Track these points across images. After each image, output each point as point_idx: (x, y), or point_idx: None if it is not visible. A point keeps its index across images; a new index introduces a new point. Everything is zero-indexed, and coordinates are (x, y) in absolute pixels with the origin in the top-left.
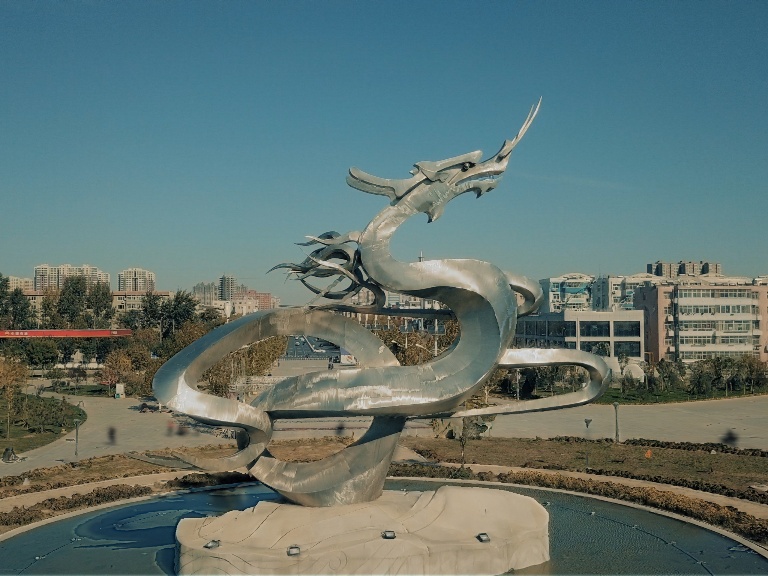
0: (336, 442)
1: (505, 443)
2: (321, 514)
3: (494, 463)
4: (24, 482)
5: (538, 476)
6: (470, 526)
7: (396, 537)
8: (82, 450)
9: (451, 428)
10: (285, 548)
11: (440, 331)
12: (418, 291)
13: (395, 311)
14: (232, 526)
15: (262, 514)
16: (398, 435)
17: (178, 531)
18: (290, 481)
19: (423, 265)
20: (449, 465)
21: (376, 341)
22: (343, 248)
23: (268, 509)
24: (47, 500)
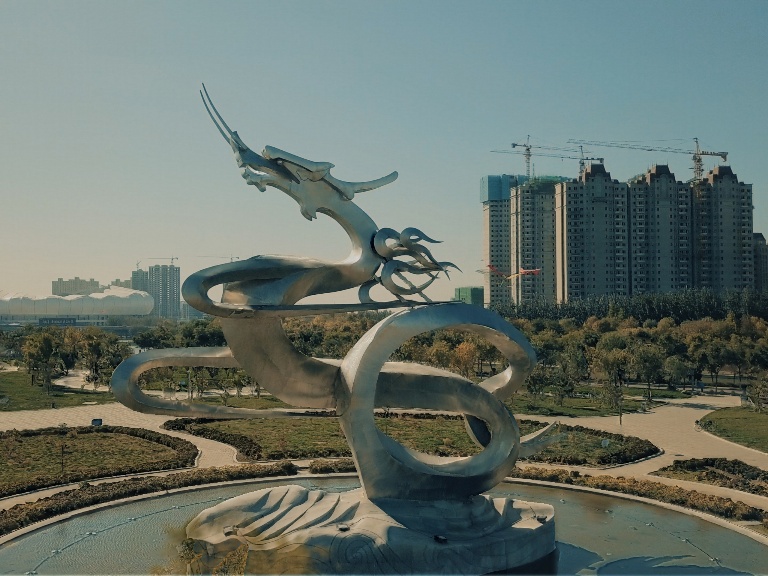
0: None
1: None
2: None
3: None
4: None
5: None
6: None
7: None
8: None
9: None
10: None
11: None
12: None
13: (350, 306)
14: None
15: None
16: None
17: None
18: None
19: None
20: None
21: None
22: None
23: None
24: None
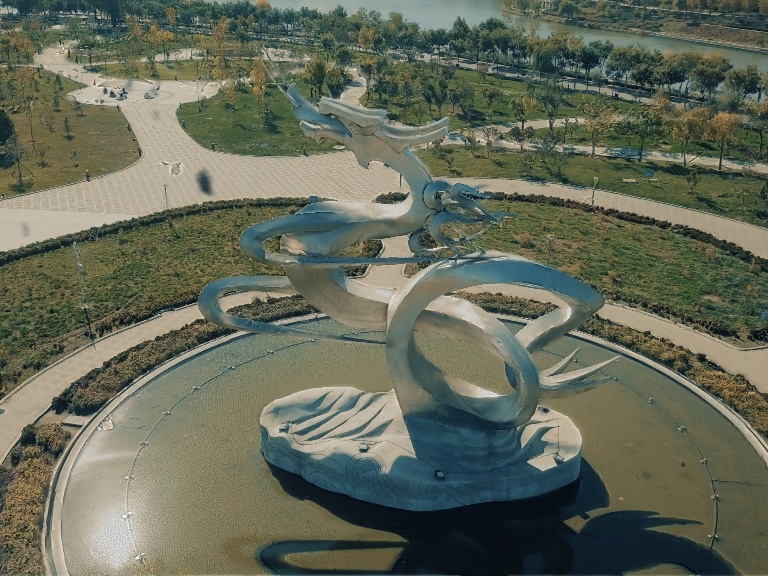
0: None
1: None
2: None
3: None
4: None
5: None
6: None
7: None
8: None
9: None
10: None
11: None
12: None
13: (393, 258)
14: None
15: None
16: None
17: None
18: None
19: None
20: None
21: None
22: None
23: None
24: None
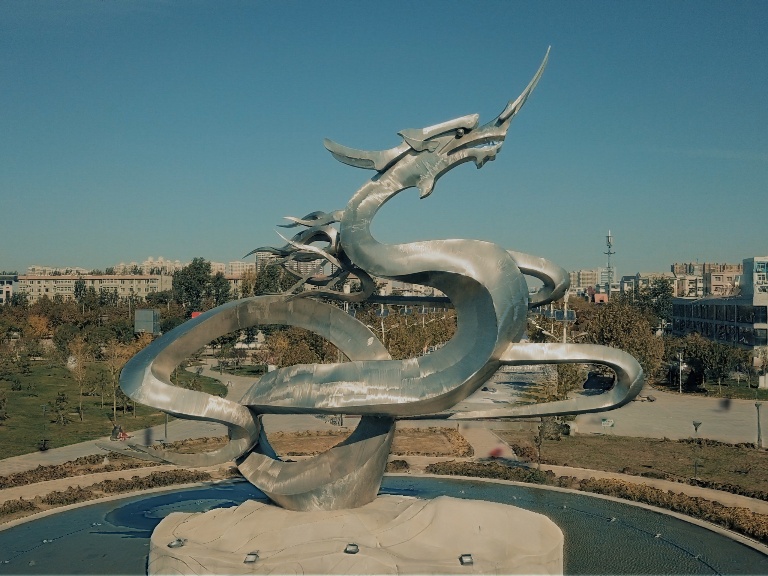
0: (439, 433)
1: (624, 443)
2: (295, 519)
3: (590, 466)
4: (104, 461)
5: (620, 485)
6: (457, 544)
7: (358, 552)
8: (189, 431)
9: (567, 423)
10: (246, 554)
11: (569, 317)
12: (405, 276)
13: (390, 298)
14: (208, 525)
15: (241, 514)
16: (384, 437)
17: (158, 526)
18: (272, 481)
19: (411, 247)
20: (537, 466)
21: (364, 332)
22: (324, 229)
23: (250, 509)
24: (104, 481)
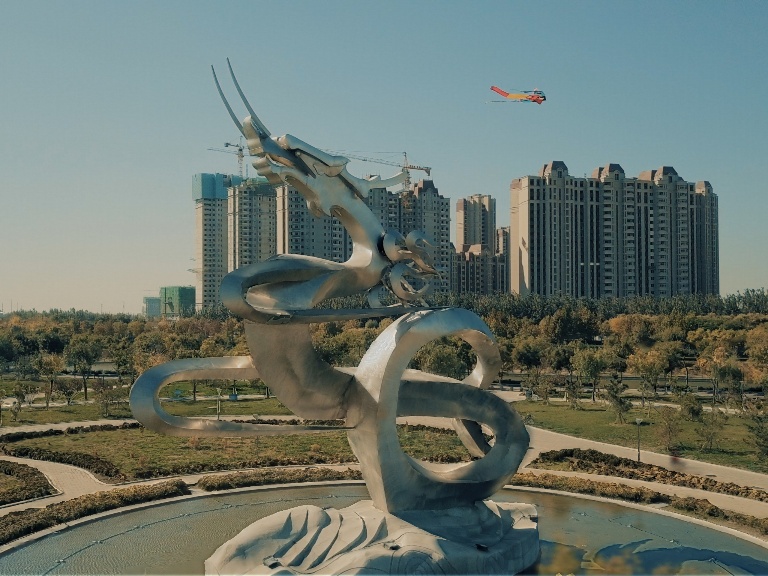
0: None
1: None
2: None
3: None
4: None
5: None
6: None
7: None
8: None
9: None
10: None
11: None
12: None
13: None
14: None
15: None
16: None
17: None
18: None
19: None
20: None
21: None
22: None
23: None
24: None
